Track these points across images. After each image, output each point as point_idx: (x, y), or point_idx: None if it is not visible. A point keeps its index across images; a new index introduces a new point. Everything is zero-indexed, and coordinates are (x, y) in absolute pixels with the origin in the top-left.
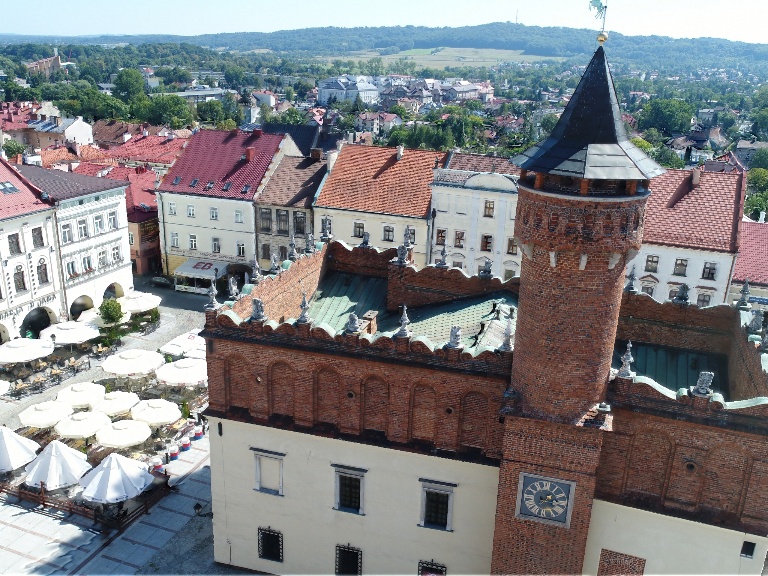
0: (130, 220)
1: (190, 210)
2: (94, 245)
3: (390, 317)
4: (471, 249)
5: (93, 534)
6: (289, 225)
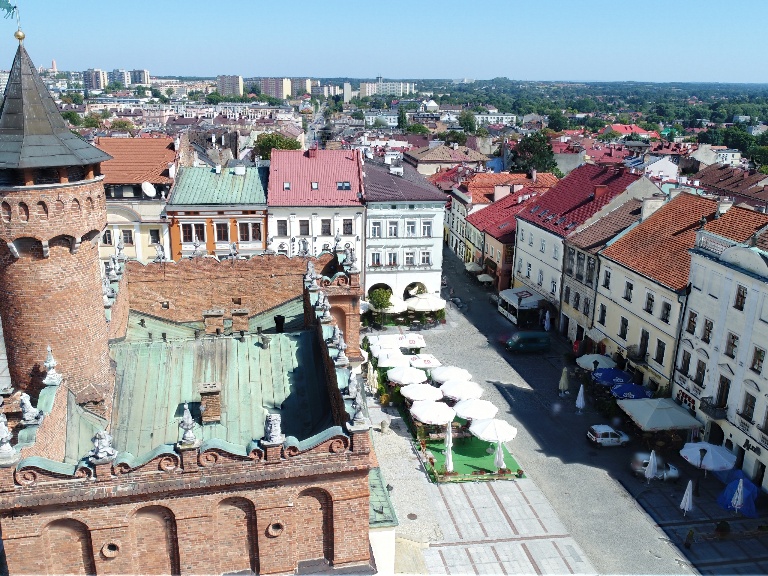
0: (500, 239)
1: (532, 239)
2: (402, 245)
3: None
4: (716, 348)
5: None
6: (584, 270)
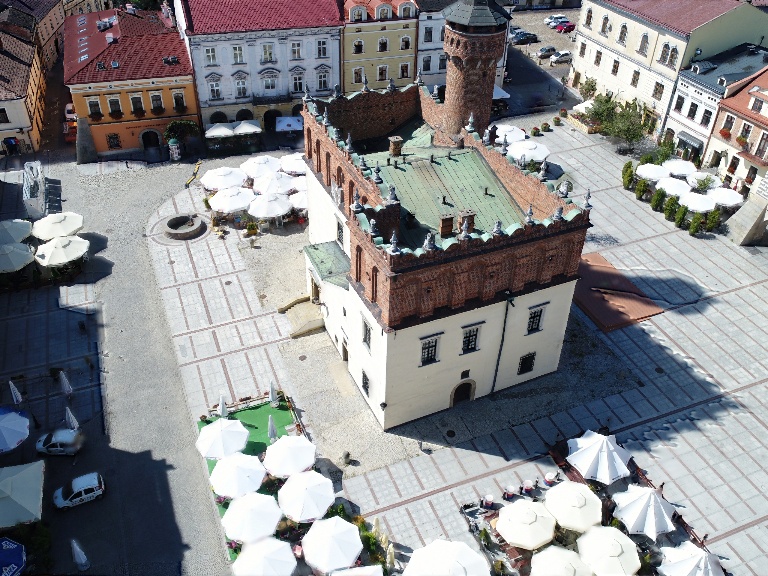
0: None
1: None
2: None
3: (404, 241)
4: None
5: (625, 446)
6: None
